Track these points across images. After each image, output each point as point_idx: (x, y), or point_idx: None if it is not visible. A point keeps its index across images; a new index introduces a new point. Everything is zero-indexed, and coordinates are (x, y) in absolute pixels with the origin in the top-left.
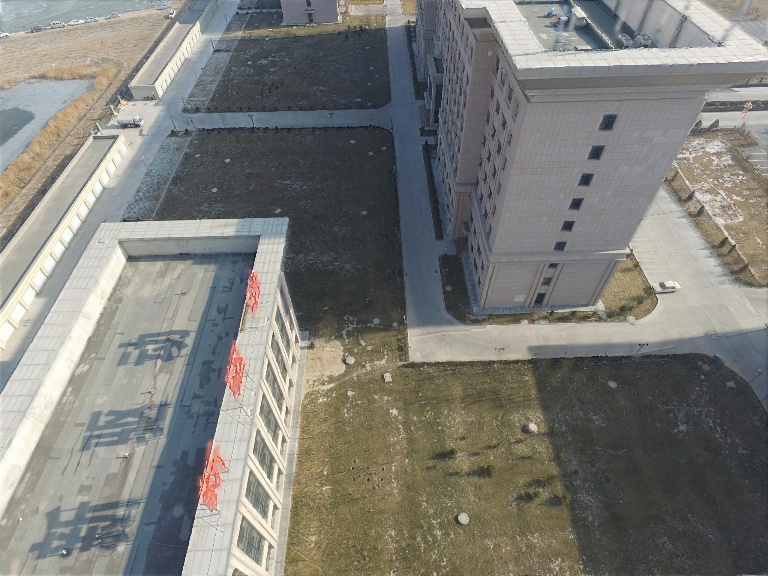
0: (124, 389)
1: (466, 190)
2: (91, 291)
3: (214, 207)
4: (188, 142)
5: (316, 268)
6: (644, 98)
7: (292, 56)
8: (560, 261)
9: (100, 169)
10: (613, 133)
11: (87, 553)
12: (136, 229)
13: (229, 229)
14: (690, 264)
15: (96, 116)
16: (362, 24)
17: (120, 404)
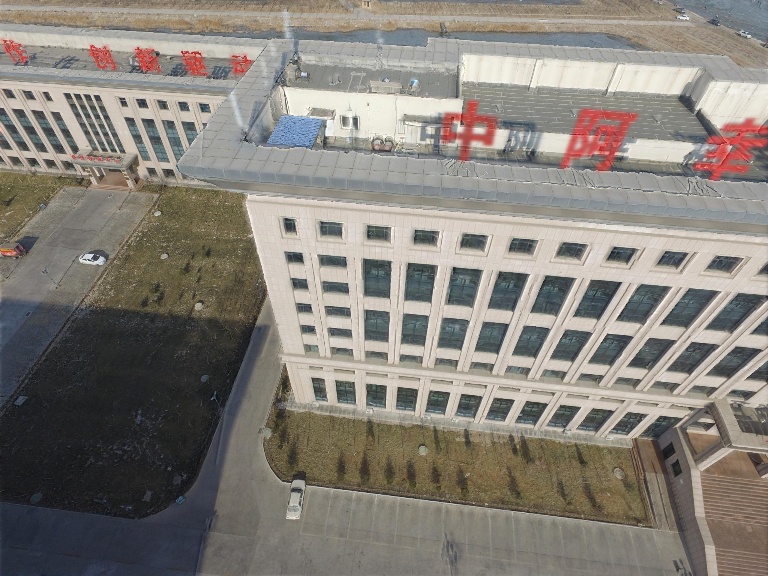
0: None
1: None
2: None
3: None
4: None
5: None
6: None
7: None
8: None
9: None
10: None
11: None
12: None
13: None
14: (331, 574)
15: None
16: None
17: None
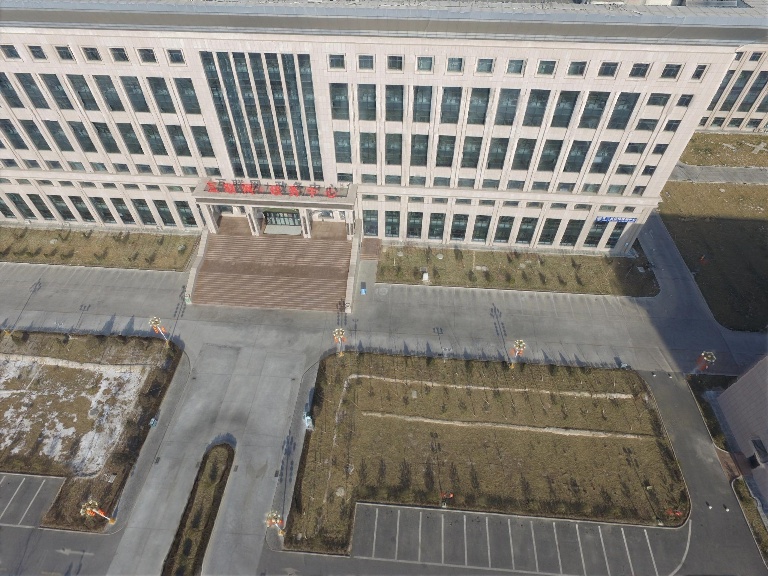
0: None
1: None
2: None
3: None
4: None
5: None
6: None
7: None
8: None
9: None
10: None
11: None
12: None
13: None
14: None
15: None
16: None
17: None
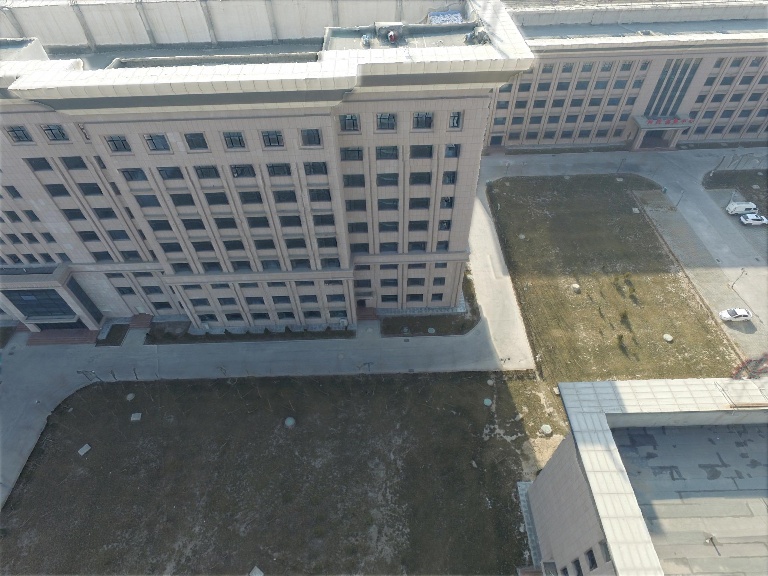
0: None
1: None
2: None
3: None
4: None
5: (402, 485)
6: None
7: None
8: None
9: None
10: None
11: None
12: None
13: (608, 463)
14: None
15: None
16: None
17: None
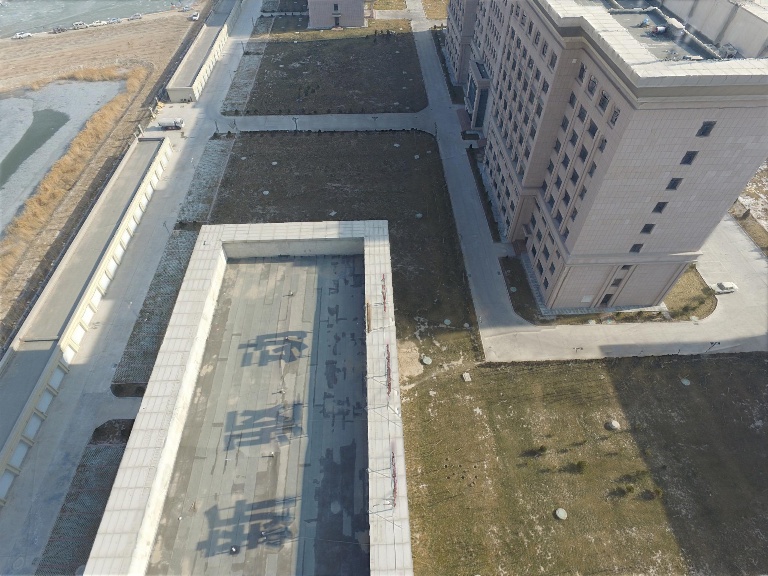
0: (254, 389)
1: (531, 193)
2: (208, 293)
3: (268, 209)
4: (232, 145)
5: None
6: (744, 106)
7: (323, 59)
8: (634, 263)
9: (151, 171)
10: (709, 139)
11: (255, 550)
12: (238, 231)
13: (331, 231)
14: (743, 265)
15: (134, 118)
16: (388, 28)
17: (253, 404)
